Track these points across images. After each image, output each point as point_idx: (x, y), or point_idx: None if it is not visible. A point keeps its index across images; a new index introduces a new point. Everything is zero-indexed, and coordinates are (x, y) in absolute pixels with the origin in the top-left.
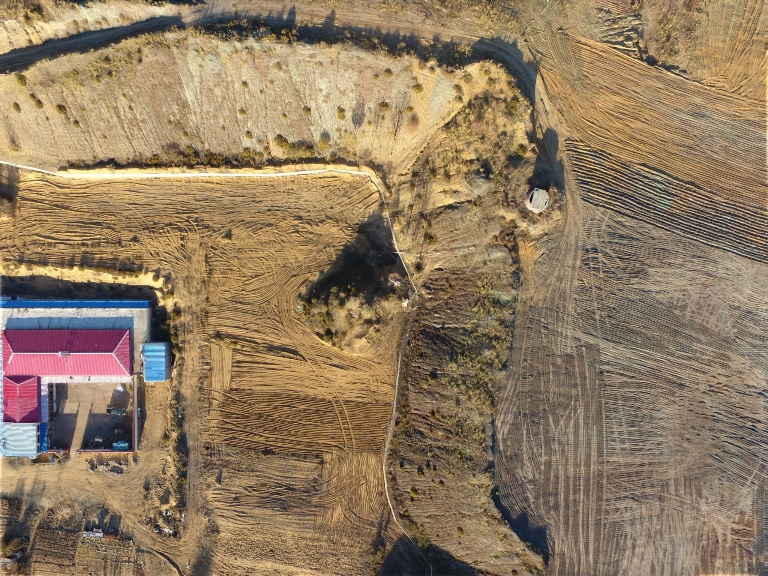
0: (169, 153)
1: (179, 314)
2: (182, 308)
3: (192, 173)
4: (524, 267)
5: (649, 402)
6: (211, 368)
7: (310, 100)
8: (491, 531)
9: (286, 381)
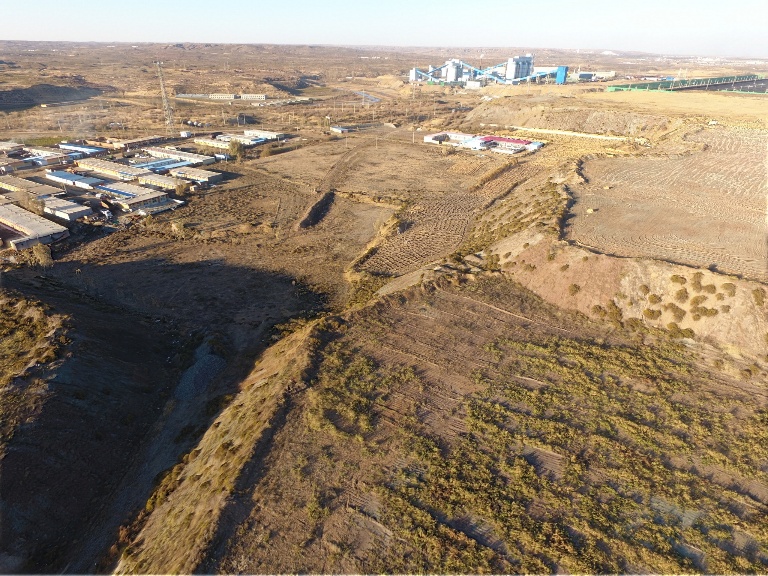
0: (571, 128)
1: (552, 143)
2: (553, 143)
3: (575, 133)
4: (706, 129)
5: (766, 142)
6: (556, 149)
7: (628, 124)
8: (678, 143)
9: (586, 152)
